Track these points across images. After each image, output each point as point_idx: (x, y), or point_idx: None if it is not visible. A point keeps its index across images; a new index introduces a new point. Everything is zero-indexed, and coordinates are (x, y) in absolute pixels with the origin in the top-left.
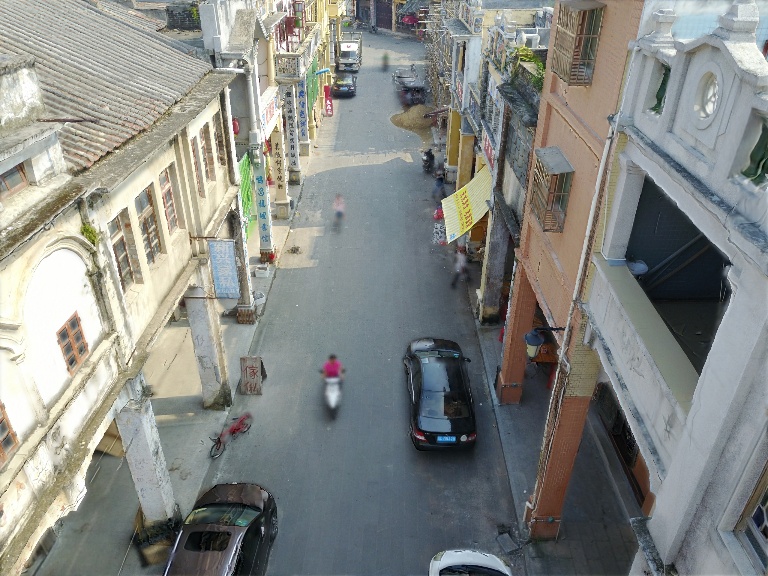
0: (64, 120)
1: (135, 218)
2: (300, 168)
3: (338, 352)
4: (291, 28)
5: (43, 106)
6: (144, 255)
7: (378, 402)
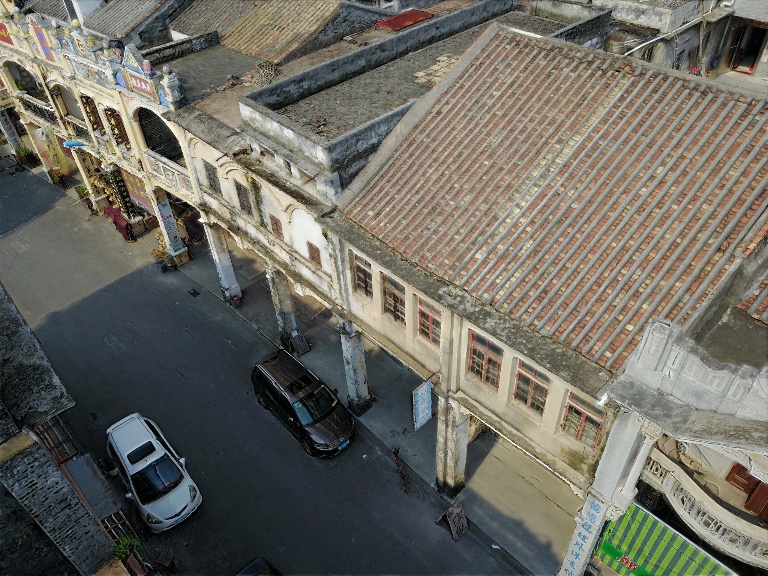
0: (314, 176)
1: (377, 277)
2: None
3: None
4: None
5: (329, 169)
6: (379, 300)
7: None
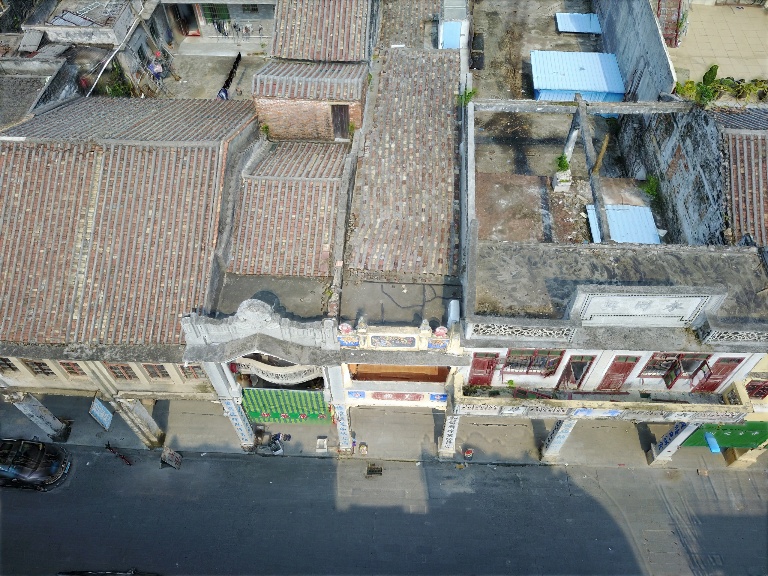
0: None
1: None
2: (547, 454)
3: (195, 520)
4: (569, 376)
5: None
6: (26, 371)
7: (130, 553)
